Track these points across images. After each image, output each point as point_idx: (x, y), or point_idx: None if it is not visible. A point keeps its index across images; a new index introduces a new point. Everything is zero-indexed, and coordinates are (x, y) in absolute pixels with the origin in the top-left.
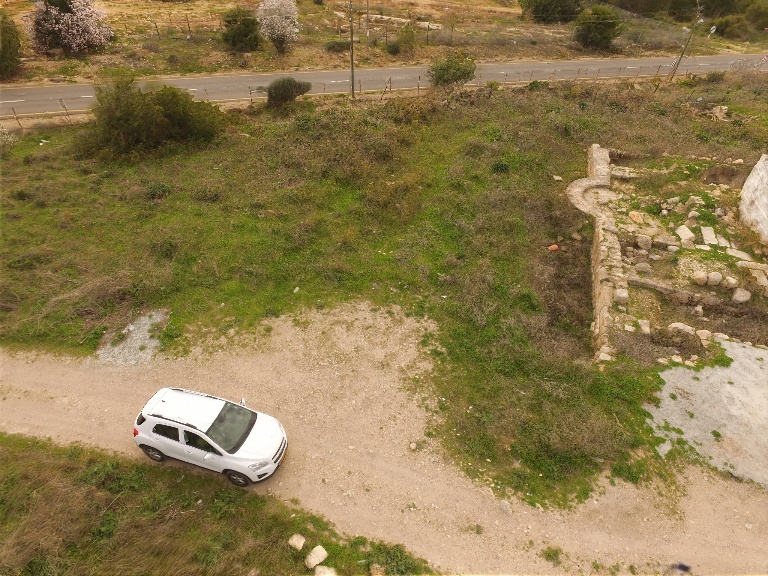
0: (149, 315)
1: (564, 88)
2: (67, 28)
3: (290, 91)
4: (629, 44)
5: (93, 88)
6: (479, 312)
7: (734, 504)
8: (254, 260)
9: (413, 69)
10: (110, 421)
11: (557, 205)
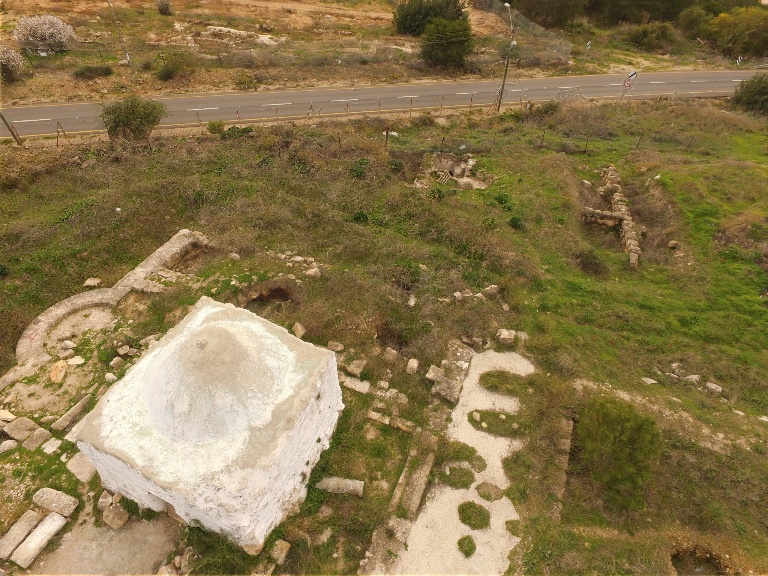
0: None
1: None
2: None
3: None
4: (496, 61)
5: None
6: None
7: None
8: None
9: None
10: None
11: (7, 337)
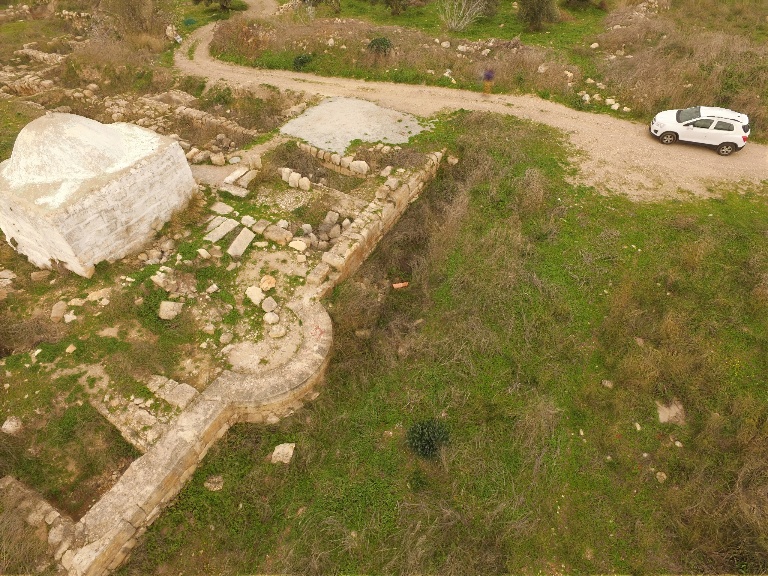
0: None
1: None
2: None
3: None
4: None
5: None
6: None
7: None
8: None
9: None
10: None
11: (355, 342)
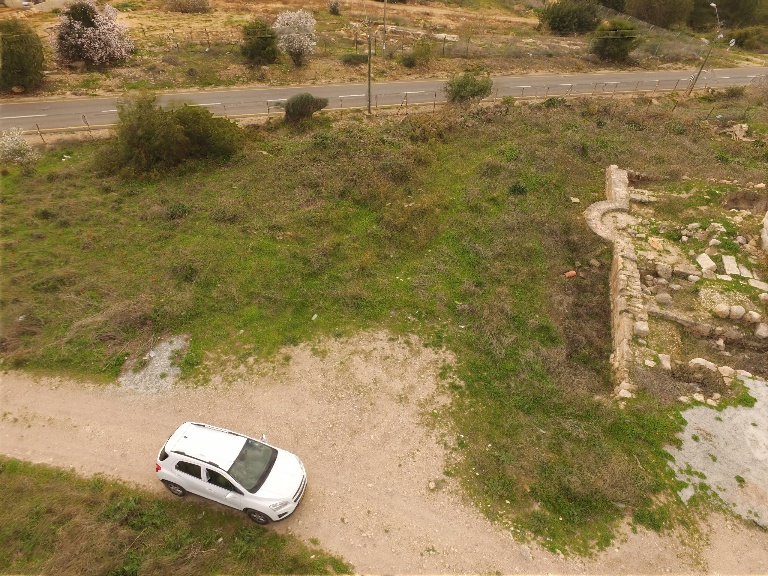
0: (170, 341)
1: (581, 105)
2: (89, 42)
3: (307, 107)
4: (646, 56)
5: (114, 102)
6: (497, 344)
7: (759, 555)
8: (273, 285)
9: (429, 83)
10: (132, 452)
11: (575, 229)
